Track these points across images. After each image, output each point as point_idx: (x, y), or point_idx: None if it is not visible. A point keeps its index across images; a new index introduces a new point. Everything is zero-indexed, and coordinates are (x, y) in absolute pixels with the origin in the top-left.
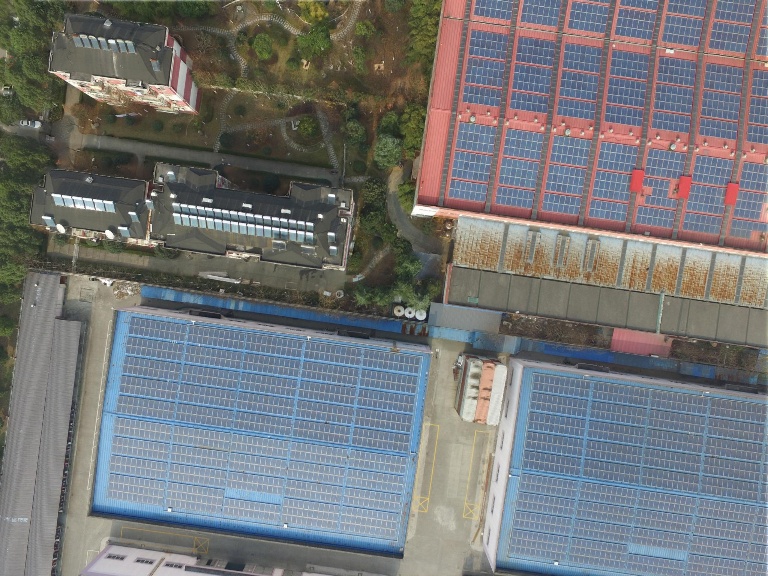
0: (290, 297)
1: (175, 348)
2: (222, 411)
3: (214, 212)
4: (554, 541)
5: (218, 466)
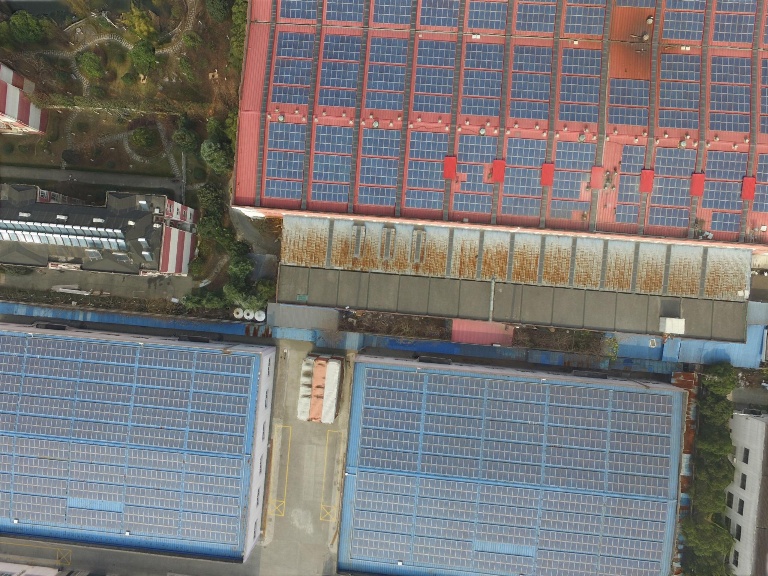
0: (139, 306)
1: (15, 361)
2: (60, 421)
3: (28, 225)
4: (396, 540)
5: (59, 476)
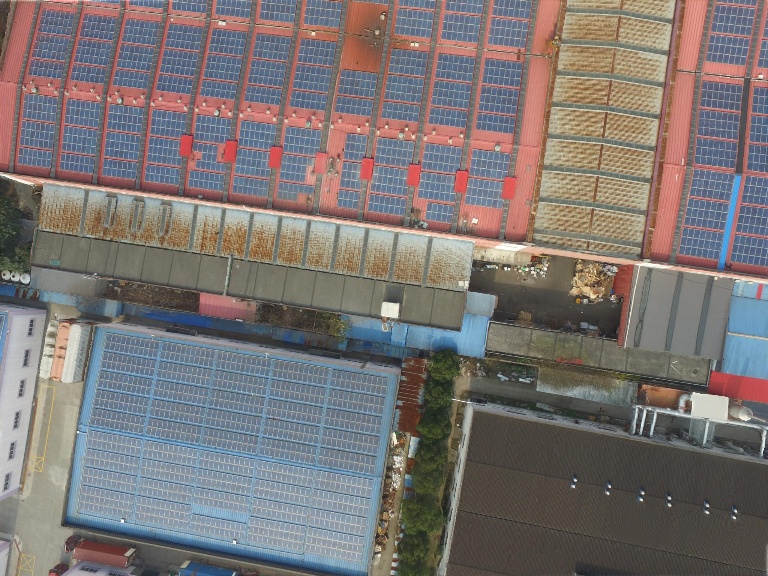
0: None
1: None
2: None
3: None
4: (120, 498)
5: None
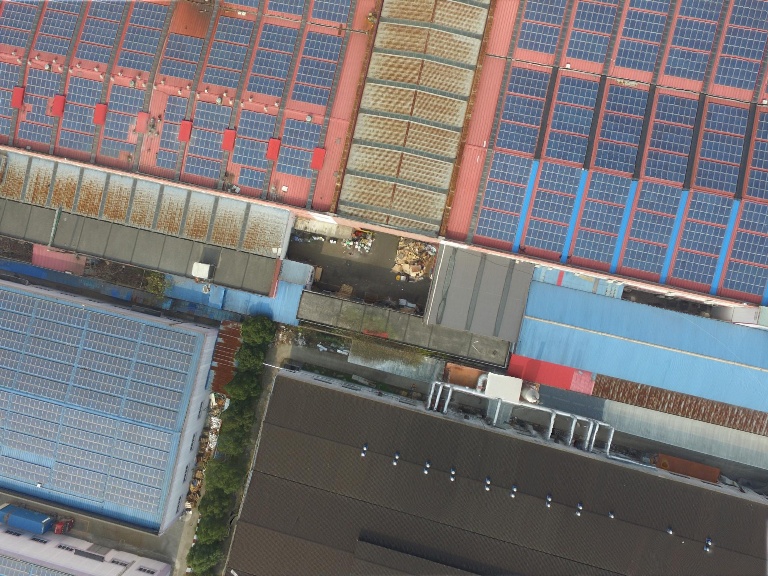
0: None
1: None
2: None
3: None
4: None
5: None
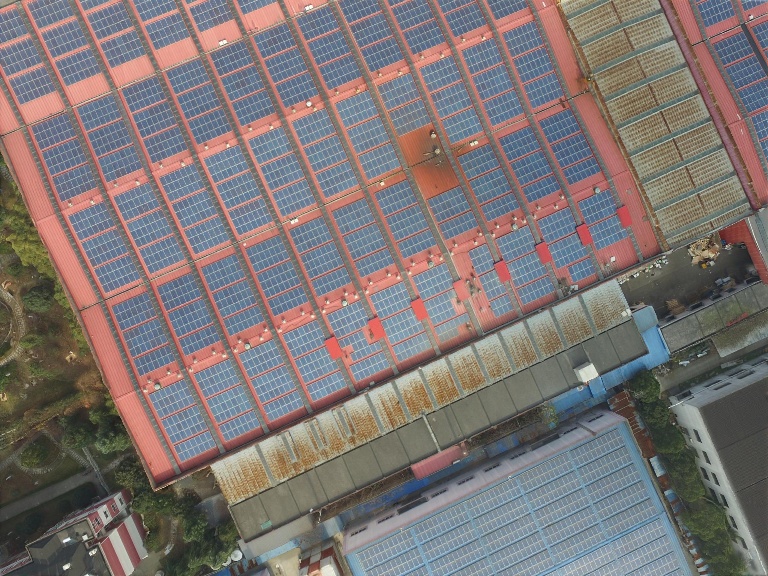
0: None
1: None
2: None
3: None
4: None
5: None
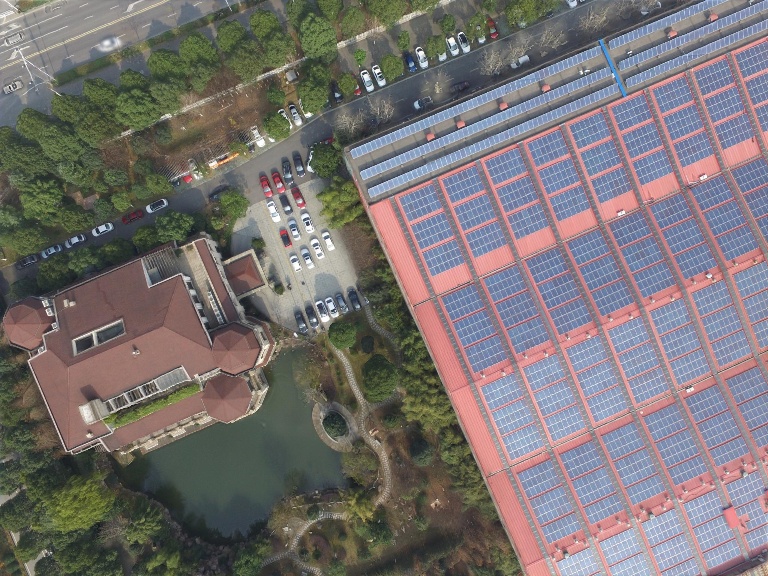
0: None
1: None
2: None
3: None
4: None
5: None
